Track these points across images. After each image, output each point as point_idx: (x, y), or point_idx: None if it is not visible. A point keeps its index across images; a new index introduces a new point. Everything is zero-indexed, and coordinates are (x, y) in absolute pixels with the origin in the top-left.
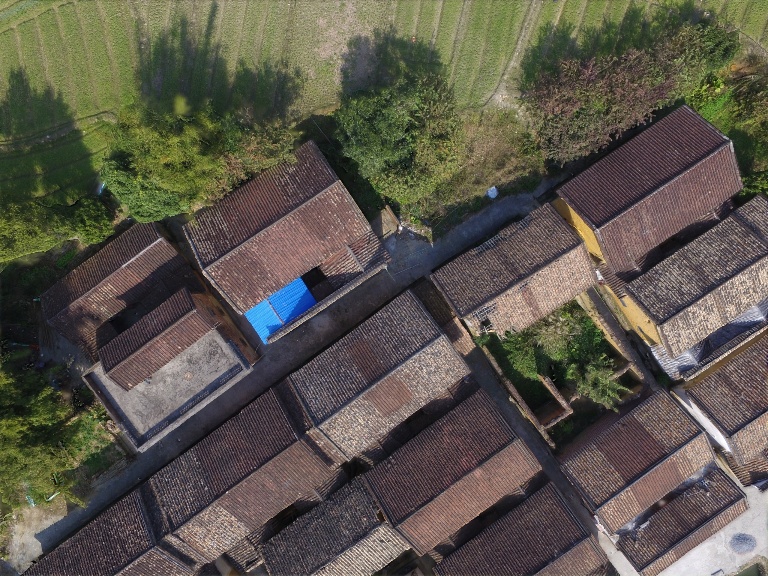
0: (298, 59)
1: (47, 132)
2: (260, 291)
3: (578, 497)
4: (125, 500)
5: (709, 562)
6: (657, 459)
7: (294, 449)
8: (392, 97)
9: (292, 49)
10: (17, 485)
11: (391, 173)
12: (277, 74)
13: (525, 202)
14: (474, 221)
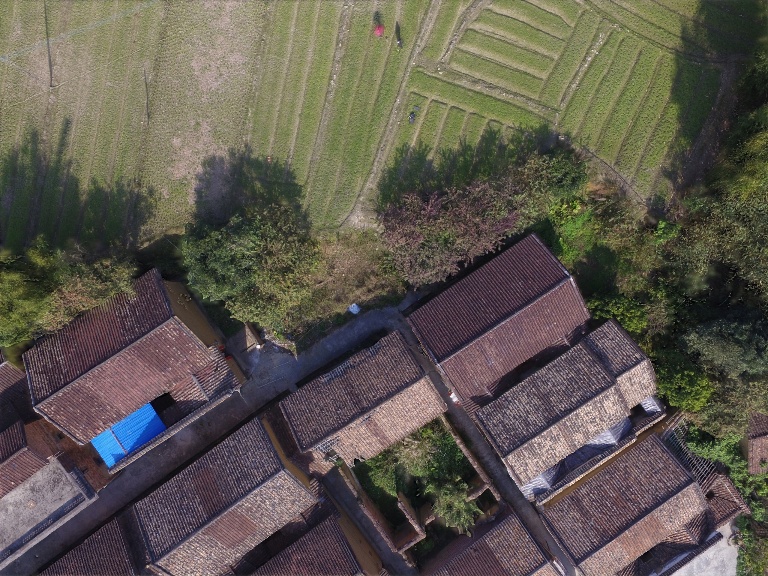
0: (151, 178)
1: None
2: (100, 422)
3: None
4: None
5: None
6: None
7: None
8: (223, 238)
9: (145, 168)
10: None
11: (236, 302)
12: (130, 192)
13: (390, 315)
14: (338, 334)
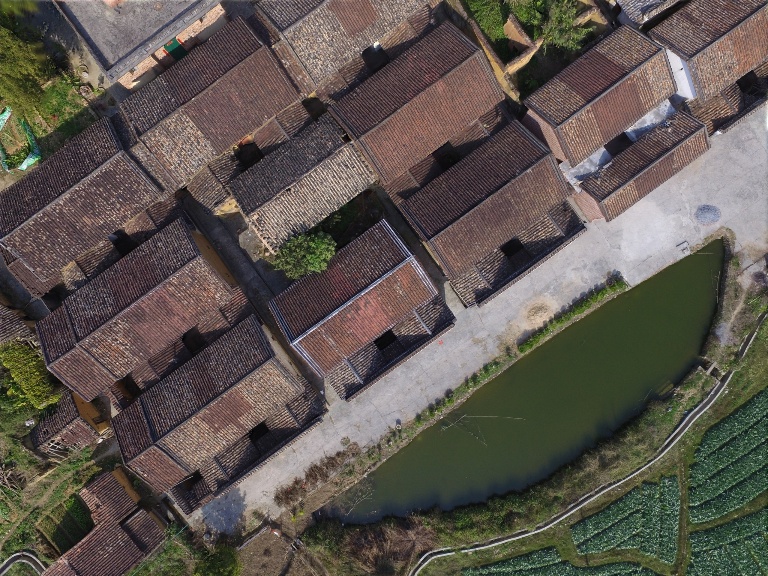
0: None
1: None
2: None
3: None
4: (94, 125)
5: (674, 234)
6: (618, 78)
7: (259, 57)
8: None
9: None
10: None
11: None
12: None
13: None
14: None
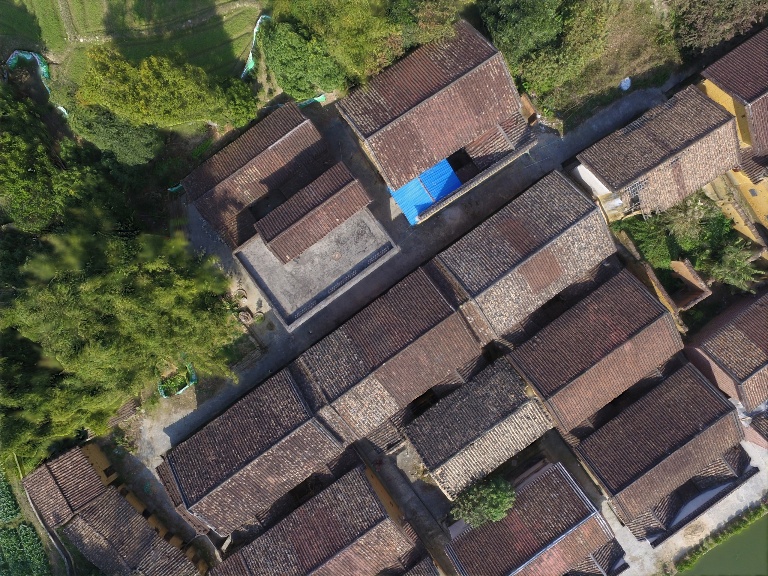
0: None
1: (188, 16)
2: (414, 167)
3: None
4: (274, 378)
5: None
6: None
7: (450, 321)
8: None
9: None
10: (185, 349)
11: (542, 52)
12: None
13: (654, 96)
14: (604, 115)
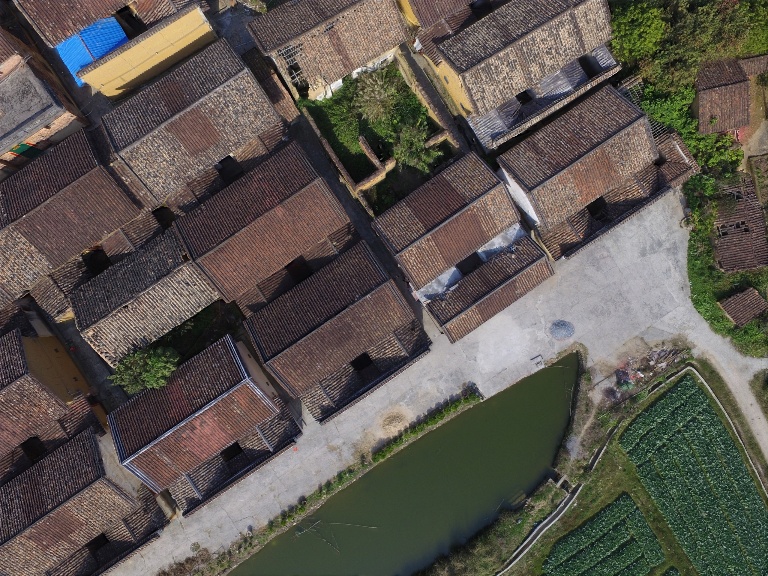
0: None
1: None
2: (70, 22)
3: (401, 275)
4: None
5: (529, 347)
6: (458, 209)
7: (95, 176)
8: None
9: None
10: None
11: None
12: None
13: None
14: None
